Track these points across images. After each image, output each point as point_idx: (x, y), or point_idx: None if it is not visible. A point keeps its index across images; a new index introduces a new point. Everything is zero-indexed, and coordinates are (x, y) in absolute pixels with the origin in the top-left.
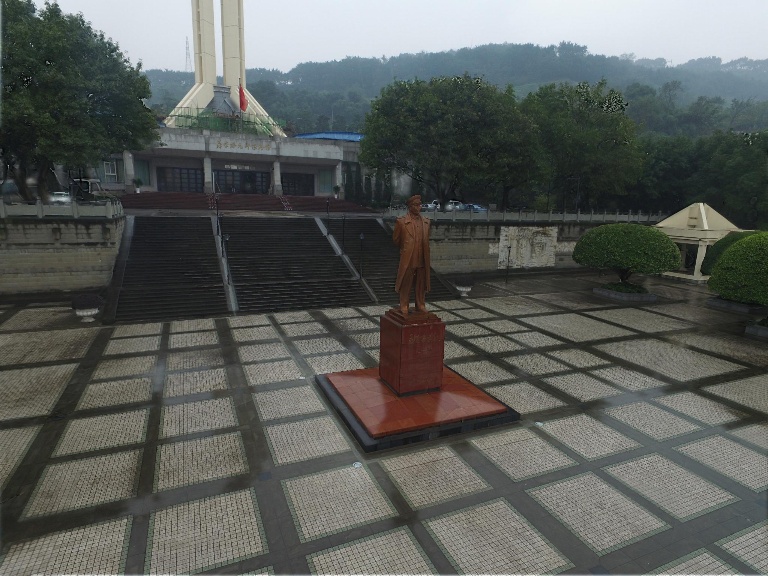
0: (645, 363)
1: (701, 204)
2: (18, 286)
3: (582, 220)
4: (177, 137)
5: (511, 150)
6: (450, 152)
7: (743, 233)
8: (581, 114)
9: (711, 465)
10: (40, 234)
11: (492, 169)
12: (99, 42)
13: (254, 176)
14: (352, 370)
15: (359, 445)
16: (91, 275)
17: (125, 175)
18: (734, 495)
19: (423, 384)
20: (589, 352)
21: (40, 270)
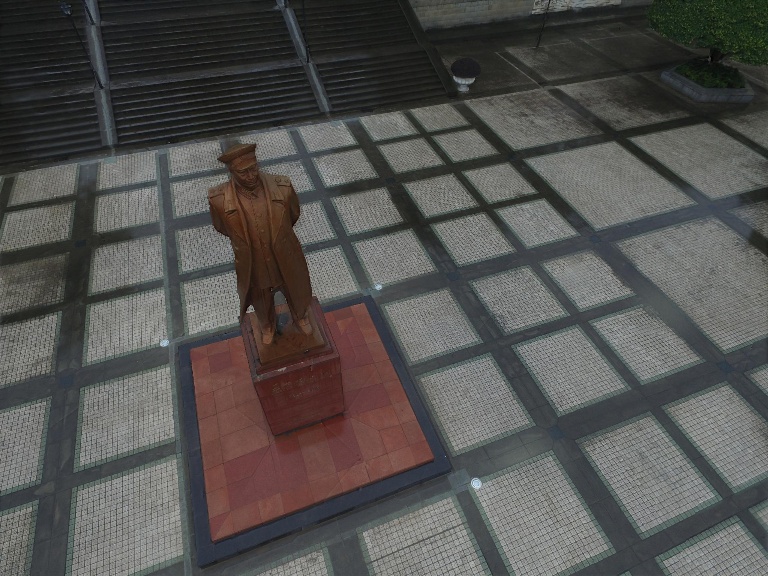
0: (683, 295)
1: None
2: None
3: None
4: None
5: None
6: None
7: None
8: None
9: None
10: None
11: None
12: None
13: None
14: None
15: None
16: None
17: None
18: None
19: (312, 418)
20: (607, 262)
21: None
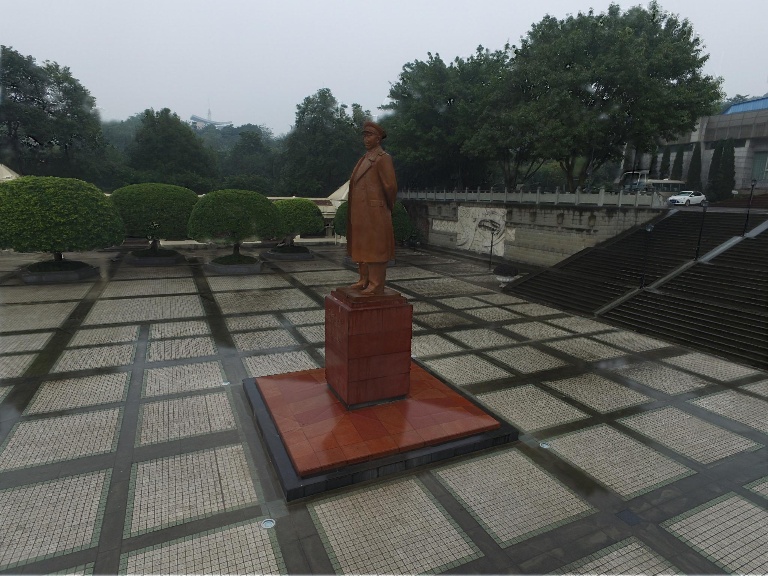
0: None
1: None
2: (534, 259)
3: None
4: None
5: None
6: None
7: None
8: None
9: None
10: (552, 218)
11: None
12: (651, 24)
13: None
14: None
15: None
16: None
17: None
18: None
19: (337, 385)
20: None
21: (546, 248)
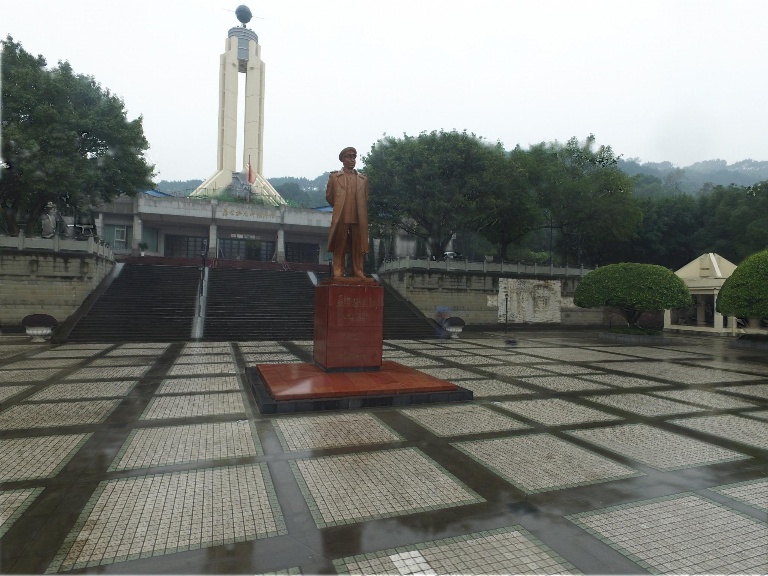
0: (646, 373)
1: (711, 254)
2: None
3: None
4: (185, 205)
5: (500, 193)
6: (436, 193)
7: None
8: (575, 172)
9: (715, 433)
10: (17, 266)
11: (481, 211)
12: (105, 98)
13: (259, 245)
14: None
15: (257, 409)
16: (63, 309)
17: (133, 240)
18: (744, 454)
19: (357, 359)
20: (580, 366)
21: (11, 302)
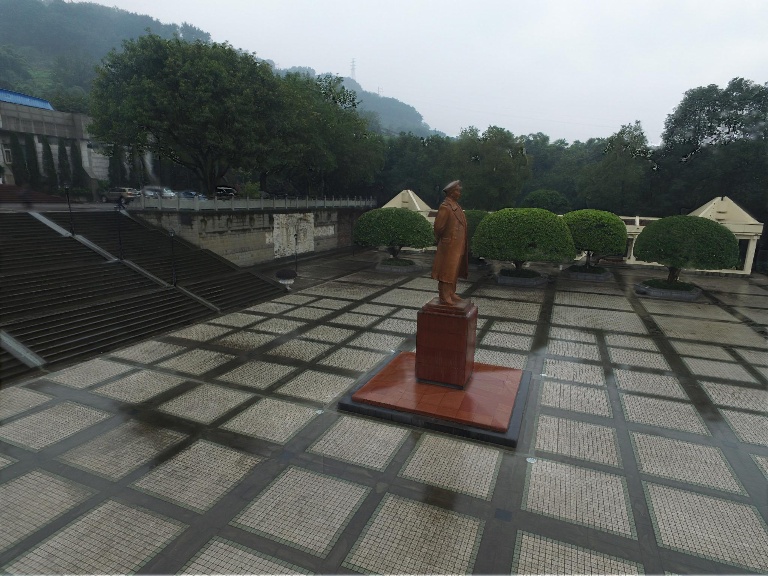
0: (501, 315)
1: (409, 191)
2: None
3: (328, 206)
4: None
5: (298, 135)
6: (252, 132)
7: (467, 212)
8: None
9: (638, 365)
10: None
11: (285, 154)
12: None
13: None
14: (365, 384)
15: (499, 445)
16: None
17: None
18: (672, 376)
19: None
20: None
21: None
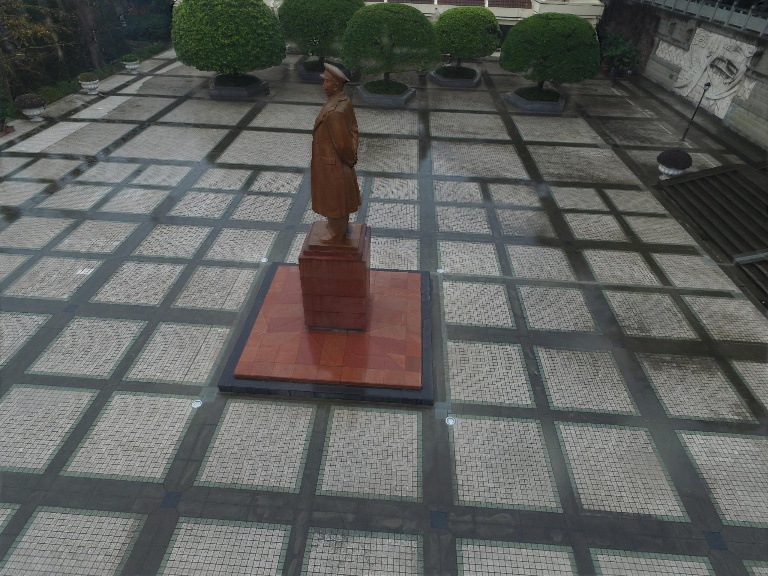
0: None
1: None
2: (759, 135)
3: None
4: None
5: None
6: None
7: None
8: None
9: None
10: None
11: None
12: None
13: None
14: None
15: None
16: None
17: None
18: None
19: None
20: None
21: None
